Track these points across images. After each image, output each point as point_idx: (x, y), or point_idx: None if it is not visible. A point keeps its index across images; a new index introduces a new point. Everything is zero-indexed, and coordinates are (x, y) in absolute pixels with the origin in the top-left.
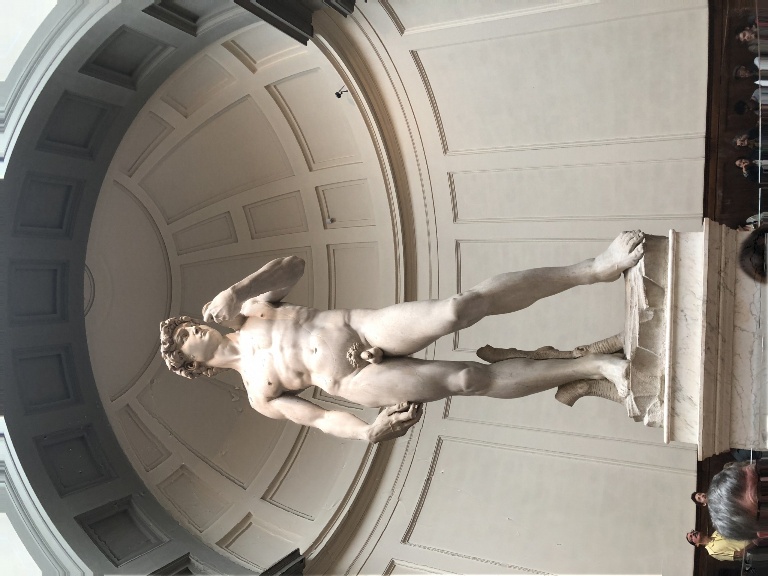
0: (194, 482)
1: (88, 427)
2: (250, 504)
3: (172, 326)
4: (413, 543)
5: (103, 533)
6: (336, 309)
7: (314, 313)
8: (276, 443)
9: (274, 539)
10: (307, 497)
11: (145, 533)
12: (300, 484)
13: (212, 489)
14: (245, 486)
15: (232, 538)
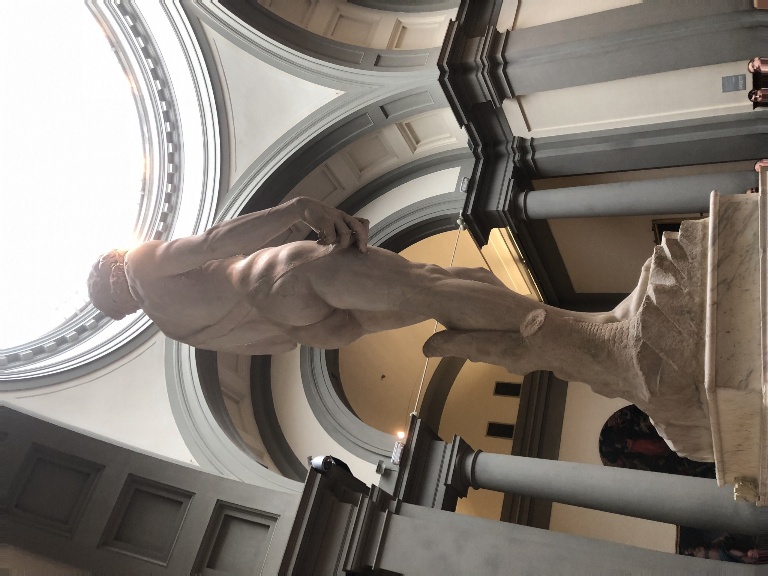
0: None
1: None
2: None
3: None
4: None
5: None
6: None
7: None
8: None
9: None
10: None
11: None
12: None
13: None
14: None
15: None
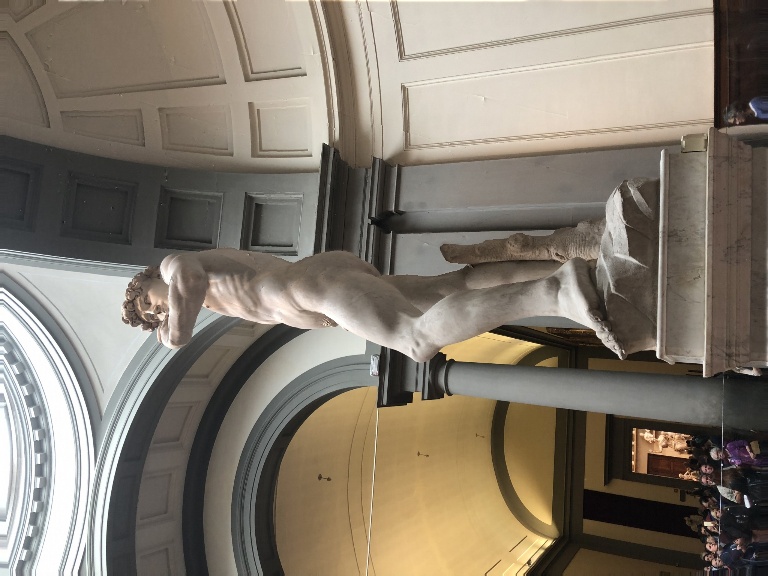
0: (182, 113)
1: (70, 175)
2: (241, 92)
3: (133, 317)
4: (410, 53)
5: (179, 229)
6: (273, 289)
7: (255, 296)
8: (206, 12)
9: (288, 112)
10: (282, 50)
11: (201, 200)
12: (264, 38)
13: (201, 107)
14: (222, 79)
15: (257, 138)
